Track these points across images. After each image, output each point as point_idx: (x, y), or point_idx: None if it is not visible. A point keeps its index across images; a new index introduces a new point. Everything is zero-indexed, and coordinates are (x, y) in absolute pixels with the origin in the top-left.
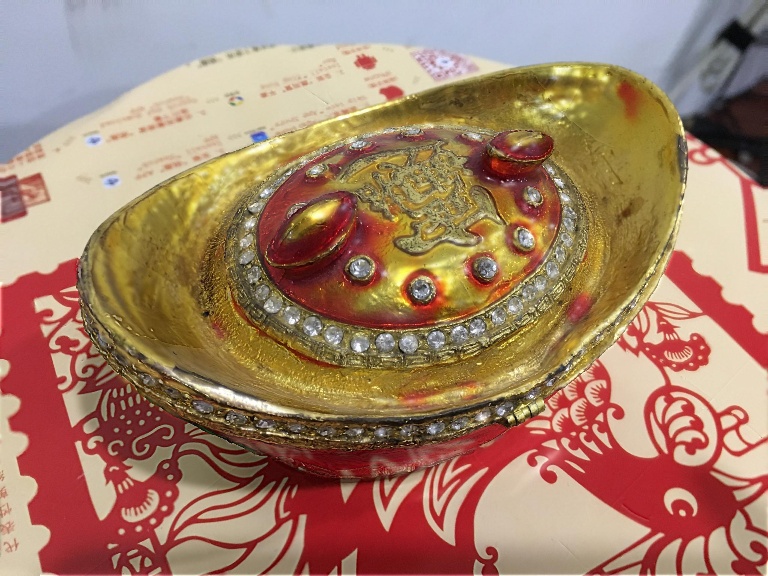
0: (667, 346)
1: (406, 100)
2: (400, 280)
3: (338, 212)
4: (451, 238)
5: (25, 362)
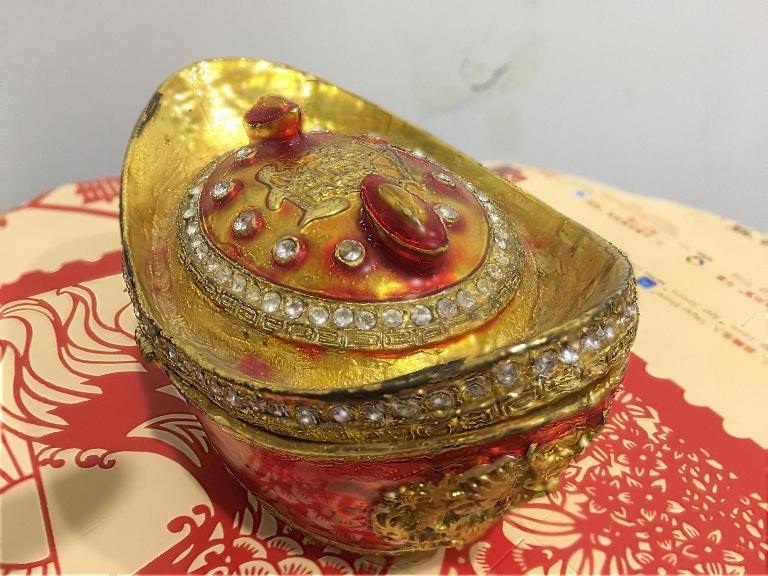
0: None
1: (561, 217)
2: (234, 177)
3: (274, 108)
4: (273, 190)
5: None
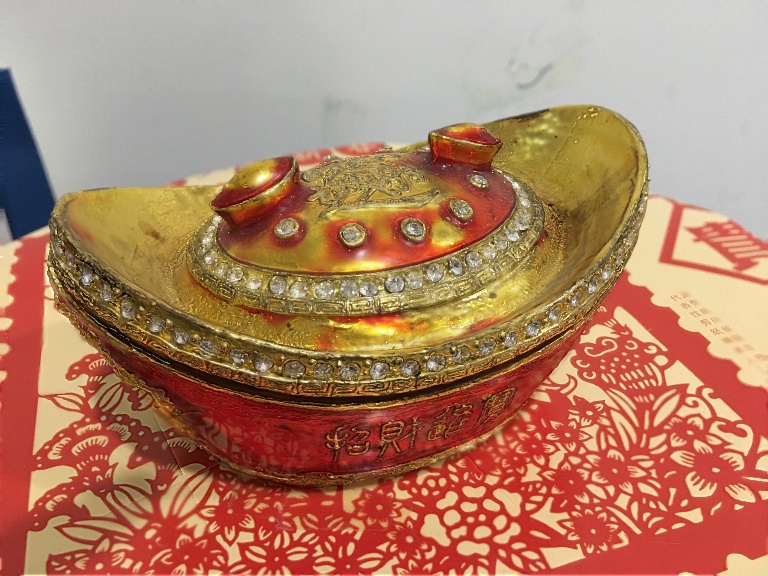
0: (110, 370)
1: (328, 352)
2: None
3: None
4: None
5: (764, 414)
